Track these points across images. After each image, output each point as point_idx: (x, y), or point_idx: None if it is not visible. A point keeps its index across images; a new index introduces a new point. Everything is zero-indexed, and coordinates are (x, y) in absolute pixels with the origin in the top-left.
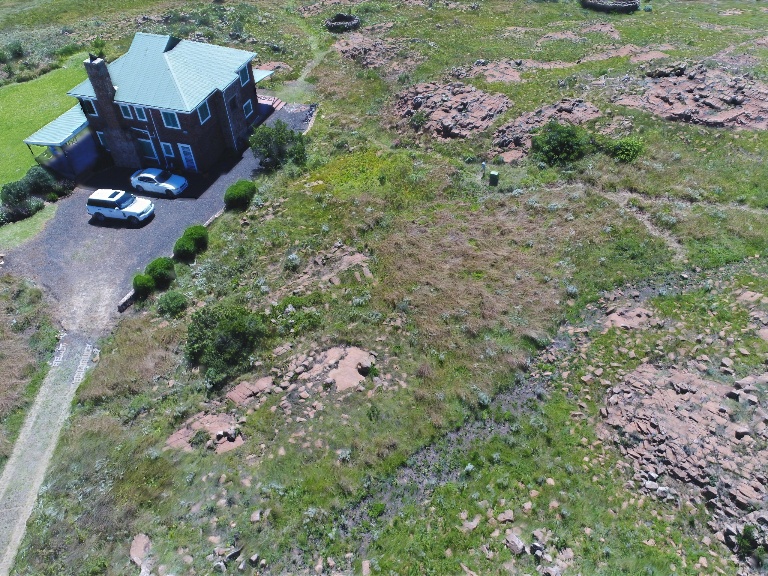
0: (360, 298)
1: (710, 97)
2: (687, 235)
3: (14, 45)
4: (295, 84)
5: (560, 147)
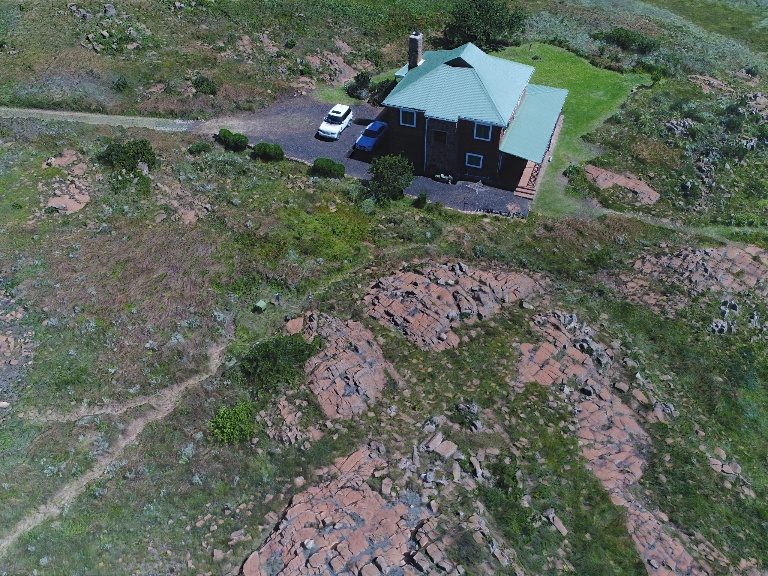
0: (132, 212)
1: (302, 567)
2: (49, 426)
3: (646, 42)
4: (591, 206)
5: (261, 350)
